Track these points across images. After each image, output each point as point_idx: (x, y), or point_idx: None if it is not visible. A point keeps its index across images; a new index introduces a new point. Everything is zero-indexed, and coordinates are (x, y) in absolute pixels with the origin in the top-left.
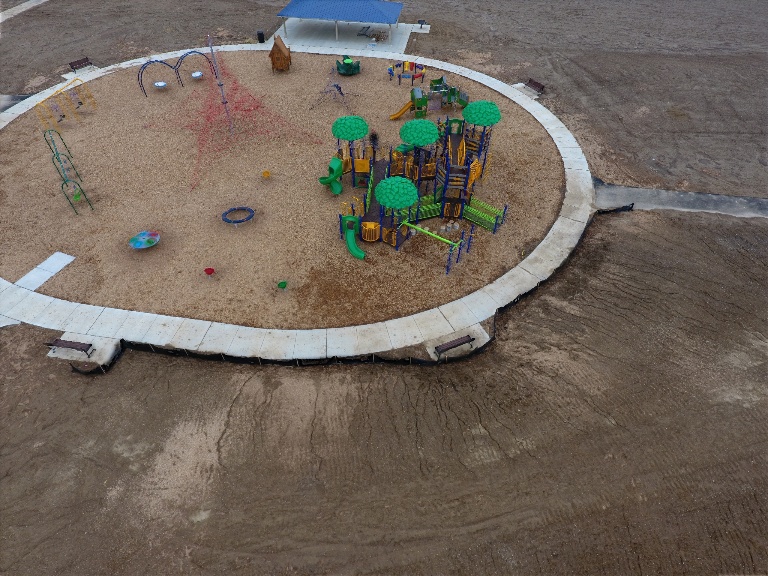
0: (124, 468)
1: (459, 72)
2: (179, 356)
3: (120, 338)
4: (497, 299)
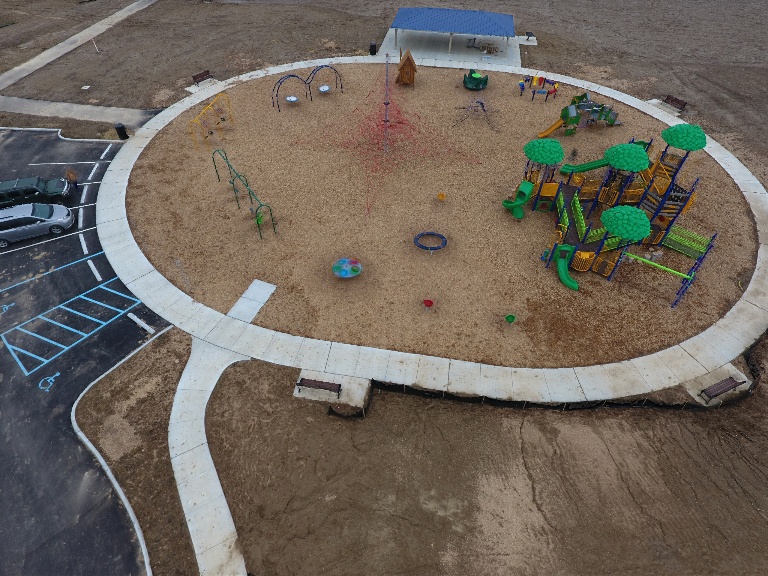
0: (447, 529)
1: (587, 87)
2: (433, 398)
3: (362, 377)
4: (737, 336)
